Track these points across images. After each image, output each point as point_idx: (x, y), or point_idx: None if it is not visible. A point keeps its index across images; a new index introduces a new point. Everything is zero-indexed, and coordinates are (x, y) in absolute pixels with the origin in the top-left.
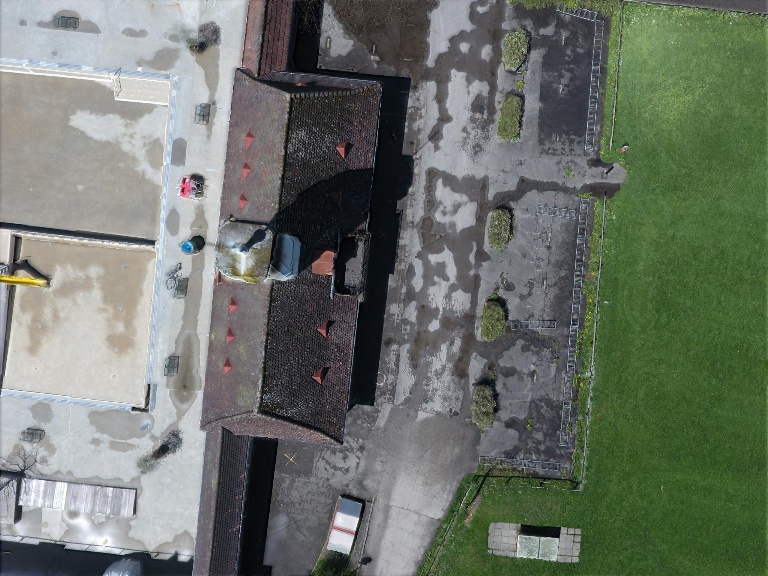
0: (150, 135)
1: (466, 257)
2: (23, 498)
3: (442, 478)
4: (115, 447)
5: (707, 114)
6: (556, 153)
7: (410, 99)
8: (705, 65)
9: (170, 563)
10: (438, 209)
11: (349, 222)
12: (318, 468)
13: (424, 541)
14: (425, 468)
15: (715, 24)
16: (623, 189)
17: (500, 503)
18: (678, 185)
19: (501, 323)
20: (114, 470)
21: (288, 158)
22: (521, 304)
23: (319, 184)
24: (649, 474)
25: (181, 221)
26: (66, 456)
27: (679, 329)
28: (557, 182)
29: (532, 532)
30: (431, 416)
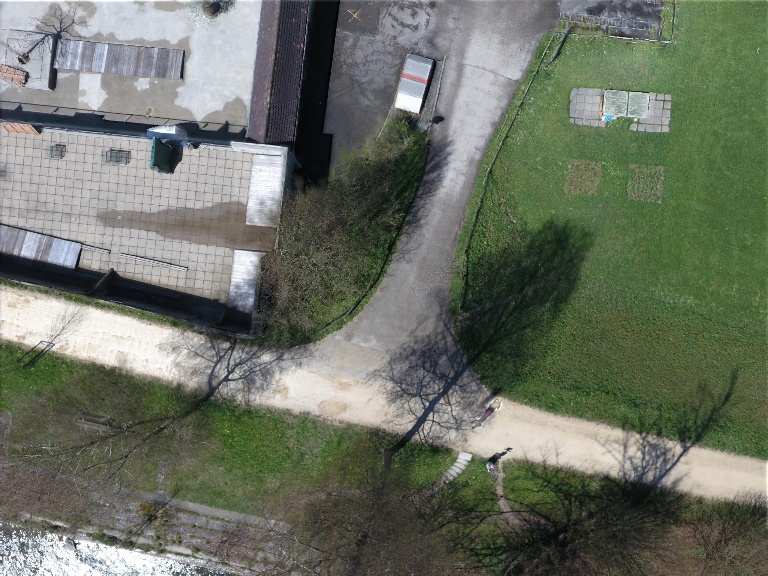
0: None
1: None
2: (59, 60)
3: (520, 36)
4: (161, 6)
5: None
6: None
7: None
8: None
9: (220, 134)
10: None
11: None
12: (384, 25)
13: (501, 102)
14: (501, 25)
15: None
16: None
17: (583, 64)
18: None
19: None
20: (160, 31)
21: None
22: None
23: None
24: (744, 35)
25: None
26: (107, 16)
27: None
28: None
29: None
30: None
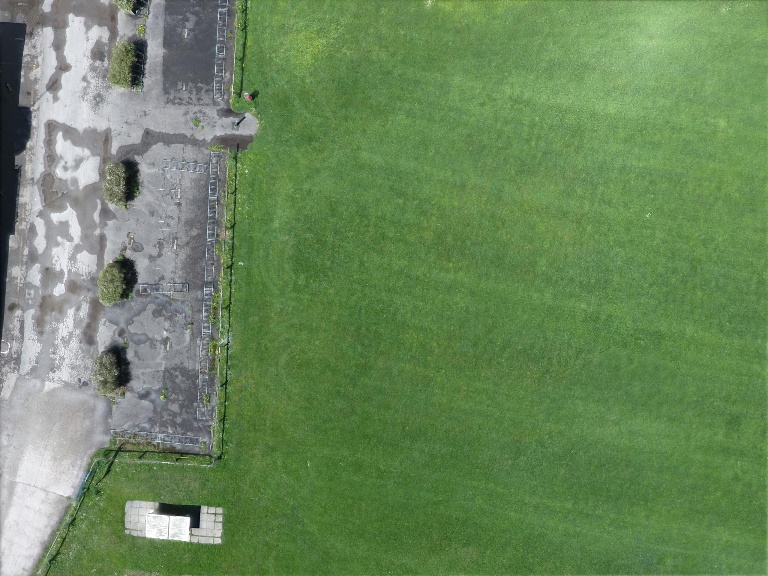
0: None
1: (90, 216)
2: None
3: (72, 453)
4: None
5: (343, 58)
6: (182, 103)
7: (25, 46)
8: (339, 5)
9: None
10: (59, 164)
11: None
12: None
13: (52, 520)
14: (54, 442)
15: None
16: (256, 141)
17: (134, 480)
18: (313, 136)
19: (115, 285)
20: None
21: None
22: (151, 266)
23: None
24: (294, 449)
25: None
26: None
27: (319, 292)
28: (185, 134)
29: (165, 511)
30: (59, 387)
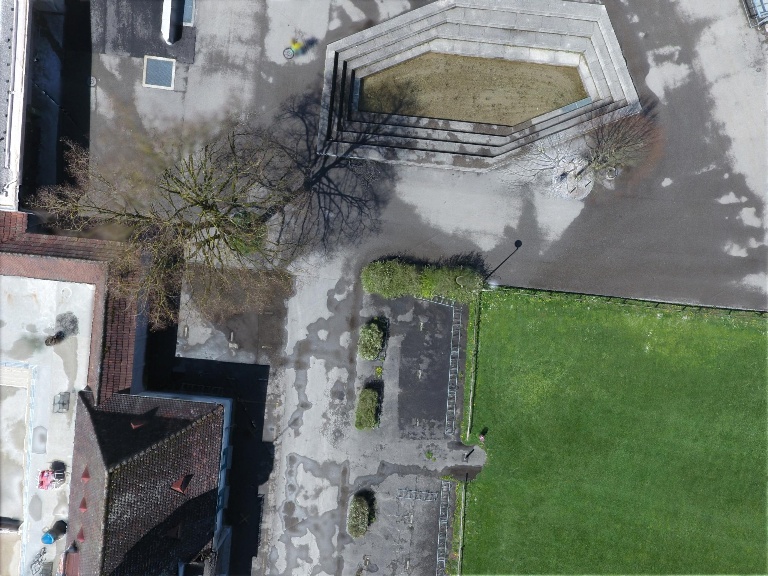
0: (13, 417)
1: (329, 540)
2: None
3: None
4: None
5: (566, 398)
6: (416, 437)
7: (269, 386)
8: (563, 350)
9: None
10: (300, 493)
11: (191, 549)
12: None
13: None
14: None
15: (573, 308)
16: (484, 471)
17: None
18: (538, 468)
19: None
20: None
21: (109, 528)
22: None
23: (151, 531)
24: None
25: (44, 507)
26: None
27: None
28: (418, 466)
29: None
30: None
